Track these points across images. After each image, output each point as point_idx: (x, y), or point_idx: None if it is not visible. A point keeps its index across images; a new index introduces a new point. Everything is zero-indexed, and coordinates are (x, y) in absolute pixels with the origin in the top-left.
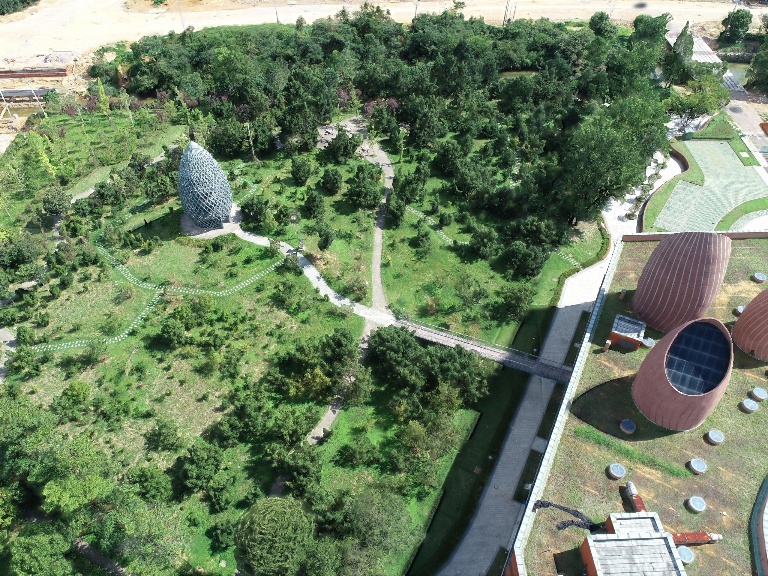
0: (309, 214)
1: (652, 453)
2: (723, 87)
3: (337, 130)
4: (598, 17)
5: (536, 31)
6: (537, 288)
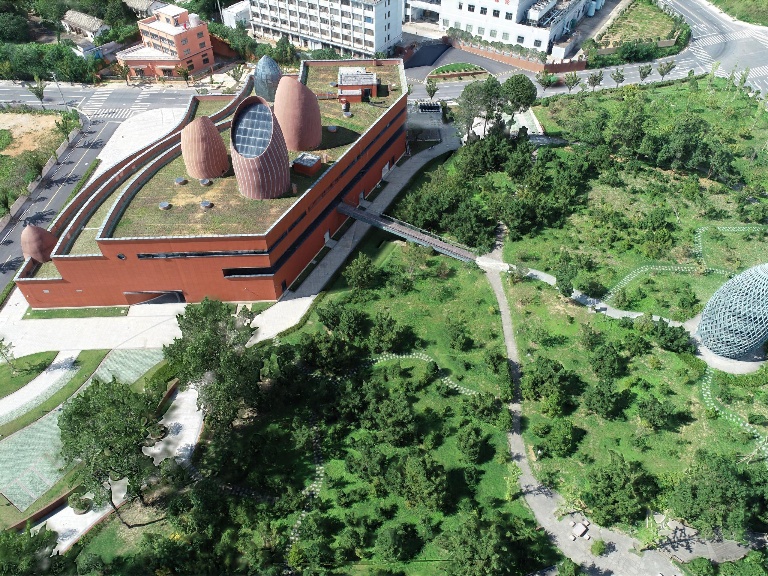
0: None
1: (324, 122)
2: None
3: None
4: None
5: None
6: None
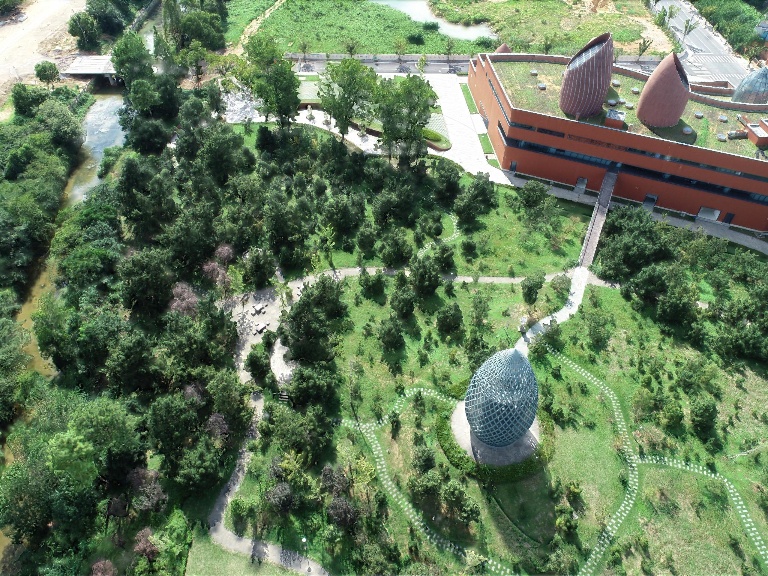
0: (455, 331)
1: (699, 127)
2: (228, 54)
3: (286, 305)
4: (22, 90)
5: (18, 140)
6: (500, 193)
